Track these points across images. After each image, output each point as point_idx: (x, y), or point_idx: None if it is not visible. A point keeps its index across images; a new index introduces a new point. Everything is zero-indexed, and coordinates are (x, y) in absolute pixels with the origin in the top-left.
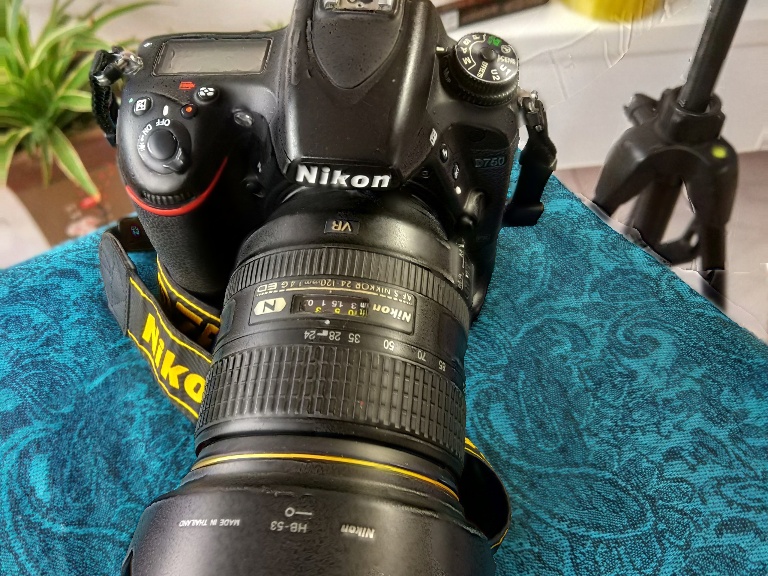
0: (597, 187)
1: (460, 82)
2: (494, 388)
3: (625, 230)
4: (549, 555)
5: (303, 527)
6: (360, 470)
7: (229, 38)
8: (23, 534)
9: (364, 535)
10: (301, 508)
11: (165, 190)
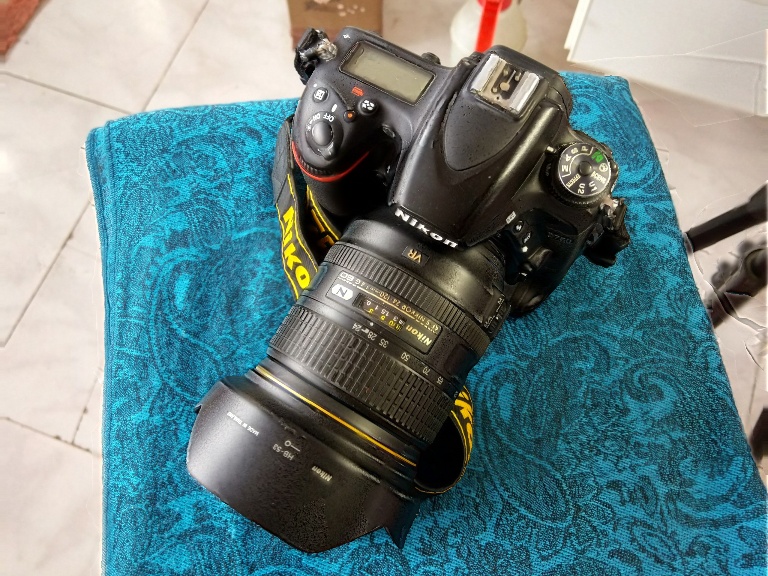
0: (755, 195)
1: (554, 181)
2: (515, 372)
3: (705, 284)
4: (484, 509)
5: (291, 457)
6: (346, 432)
7: (406, 59)
8: (158, 326)
9: (324, 478)
10: (295, 444)
11: (314, 164)
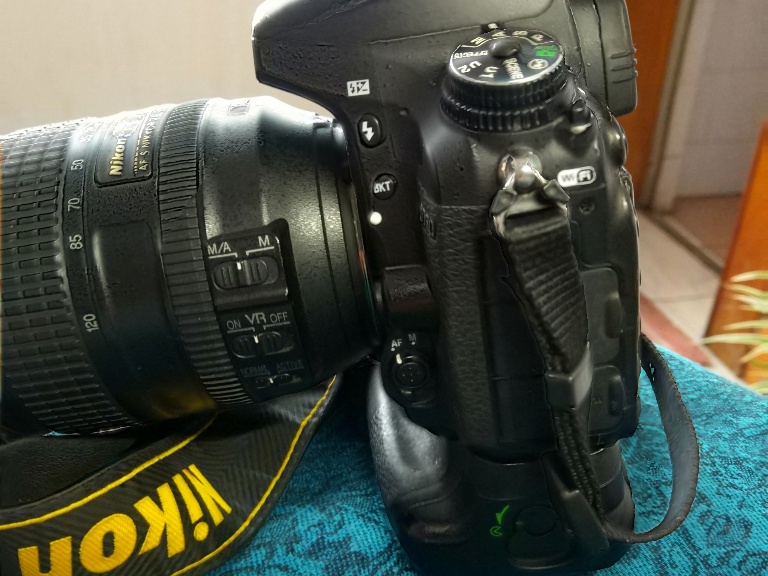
0: None
1: None
2: None
3: None
4: None
5: None
6: None
7: None
8: None
9: None
10: None
11: None
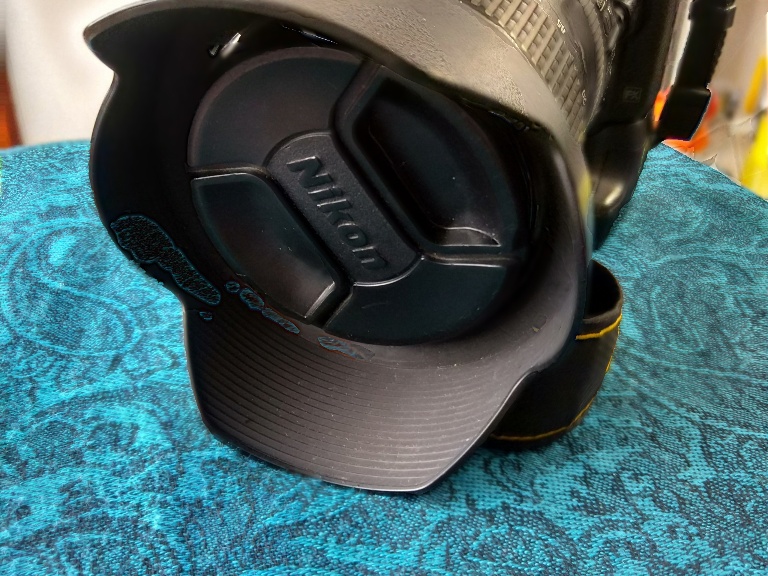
0: None
1: None
2: None
3: None
4: (668, 438)
5: None
6: None
7: None
8: (16, 281)
9: None
10: None
11: None
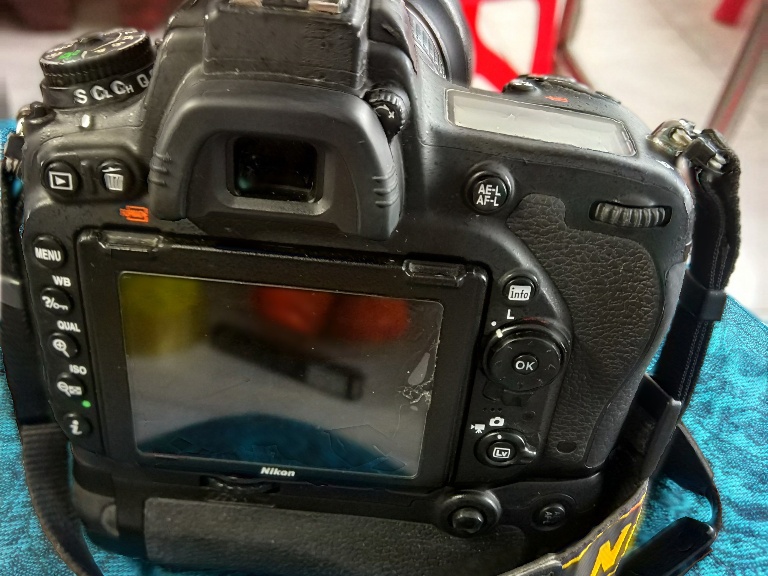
0: None
1: None
2: None
3: None
4: None
5: None
6: None
7: (525, 139)
8: None
9: None
10: None
11: None
